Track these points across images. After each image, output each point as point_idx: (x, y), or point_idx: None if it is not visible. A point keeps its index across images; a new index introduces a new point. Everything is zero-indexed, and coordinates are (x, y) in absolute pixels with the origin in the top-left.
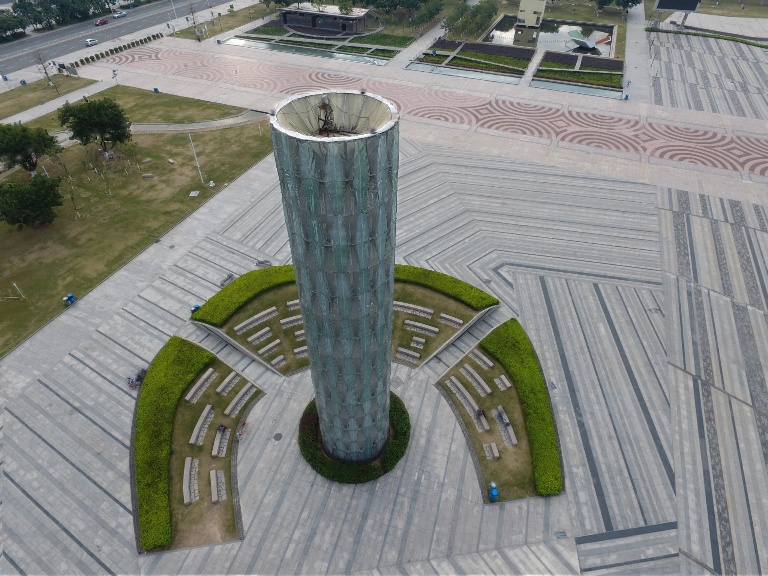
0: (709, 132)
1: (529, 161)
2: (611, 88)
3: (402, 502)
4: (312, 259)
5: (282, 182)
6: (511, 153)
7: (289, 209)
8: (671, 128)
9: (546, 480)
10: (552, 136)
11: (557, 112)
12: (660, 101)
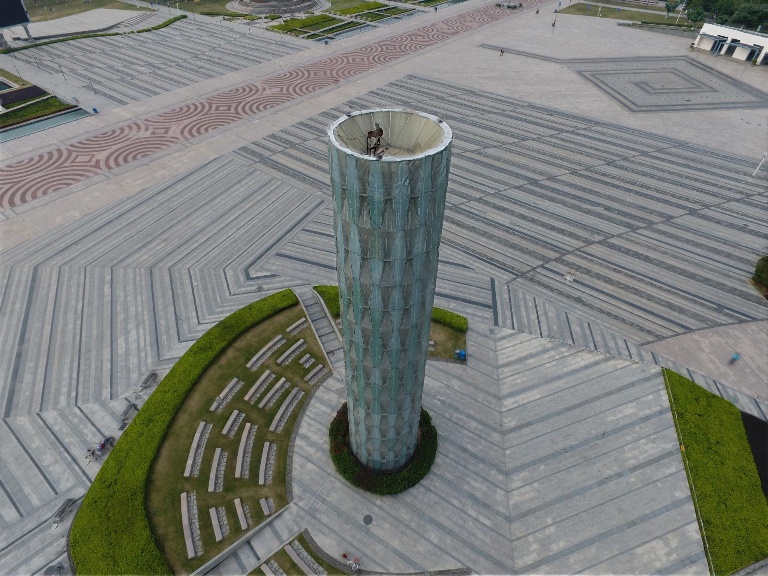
0: (189, 105)
1: (118, 200)
2: (68, 110)
3: (457, 418)
4: (427, 266)
5: (406, 214)
6: (91, 205)
7: (409, 237)
8: (164, 115)
9: (459, 322)
10: (97, 171)
11: (61, 152)
12: (122, 101)
